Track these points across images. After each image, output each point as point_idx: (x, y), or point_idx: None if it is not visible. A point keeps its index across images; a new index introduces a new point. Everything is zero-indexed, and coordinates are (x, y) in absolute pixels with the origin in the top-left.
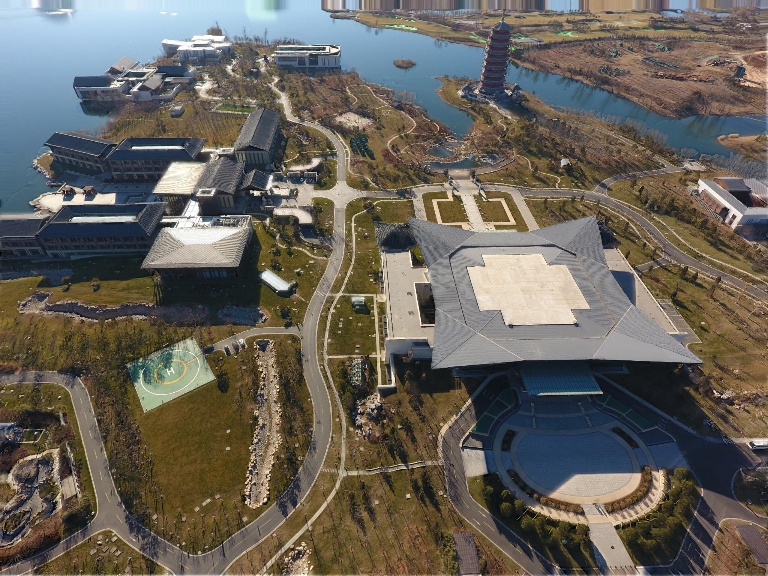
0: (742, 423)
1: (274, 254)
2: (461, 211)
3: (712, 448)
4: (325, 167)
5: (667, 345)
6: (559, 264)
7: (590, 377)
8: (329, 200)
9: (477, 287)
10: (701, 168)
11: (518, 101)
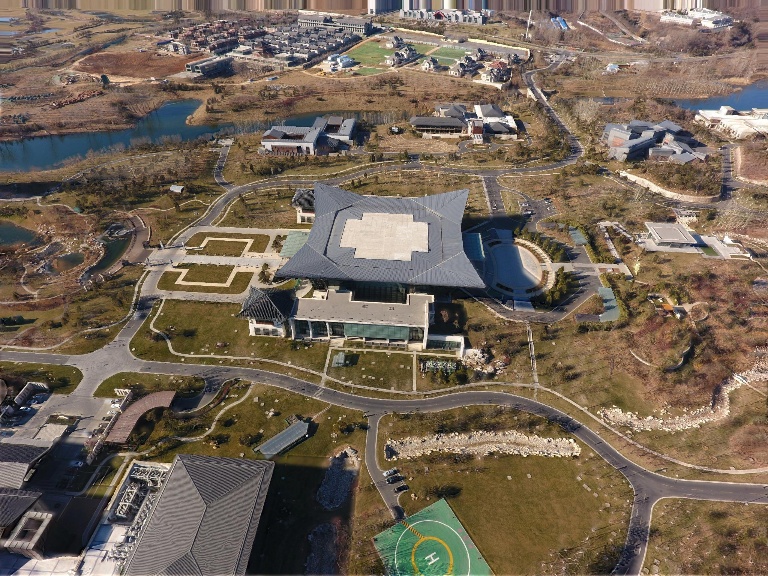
0: (479, 206)
1: (223, 442)
2: (212, 267)
3: (497, 219)
4: (9, 376)
5: (453, 196)
6: (362, 215)
7: (467, 234)
8: (114, 377)
9: (383, 257)
10: (230, 141)
11: (3, 183)
